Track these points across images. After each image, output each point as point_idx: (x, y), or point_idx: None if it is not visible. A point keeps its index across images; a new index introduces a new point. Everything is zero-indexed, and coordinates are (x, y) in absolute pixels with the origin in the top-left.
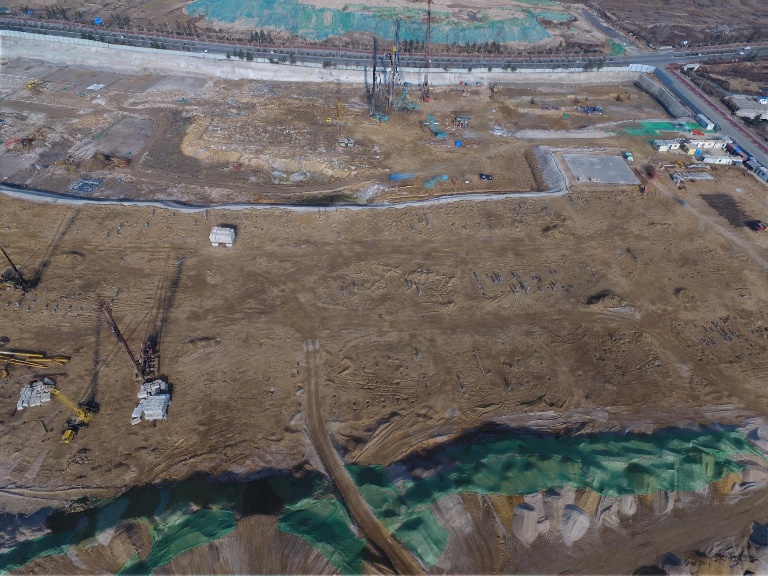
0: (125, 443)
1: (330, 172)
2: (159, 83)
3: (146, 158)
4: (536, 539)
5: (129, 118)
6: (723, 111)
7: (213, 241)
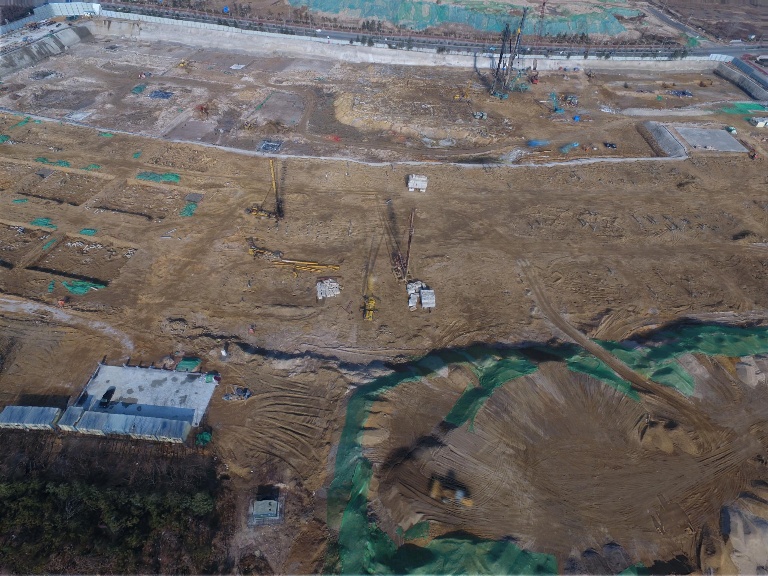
0: (412, 322)
1: (474, 139)
2: (291, 65)
3: (310, 125)
4: (758, 384)
5: (278, 93)
6: None
7: (410, 187)
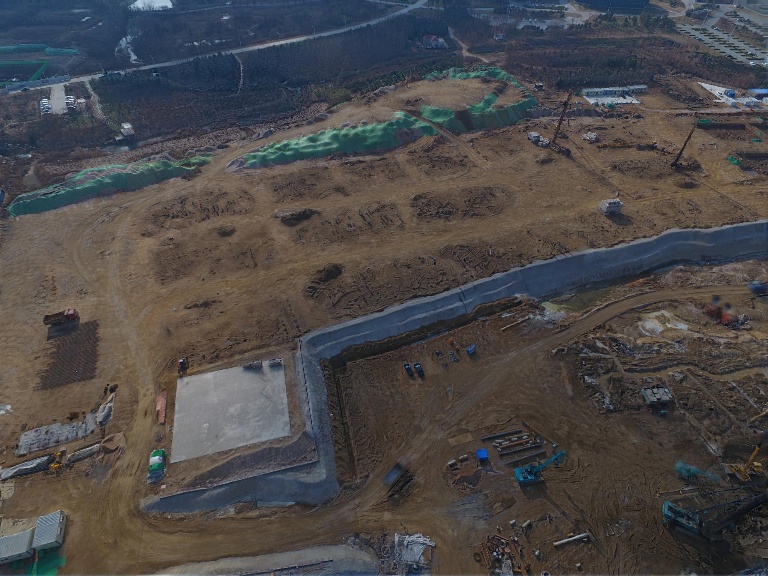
0: None
1: (622, 335)
2: None
3: None
4: None
5: None
6: None
7: None
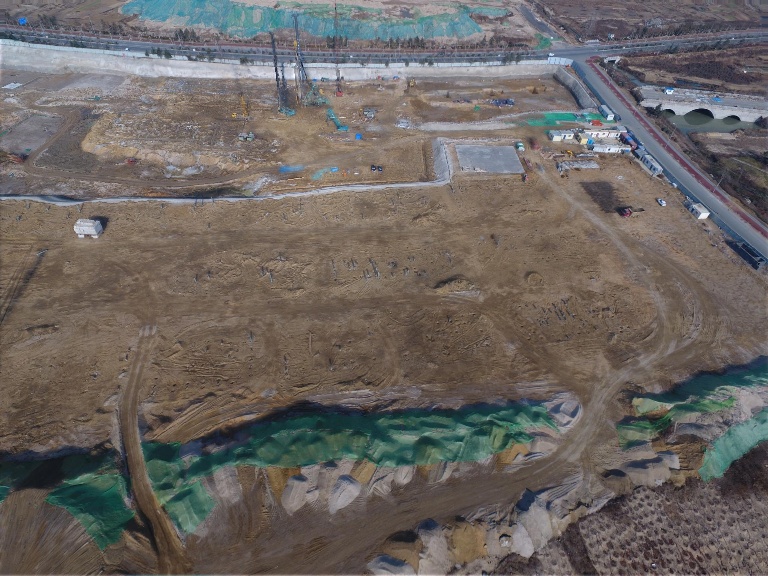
0: None
1: (223, 166)
2: (77, 81)
3: (44, 154)
4: (301, 508)
5: (38, 116)
6: (629, 102)
7: (78, 233)
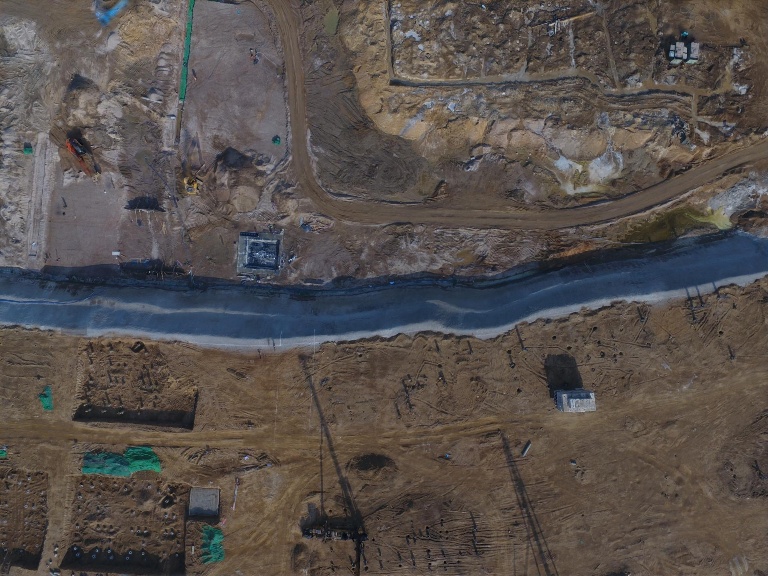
0: None
1: (662, 152)
2: None
3: (317, 153)
4: None
5: (204, 3)
6: None
7: None
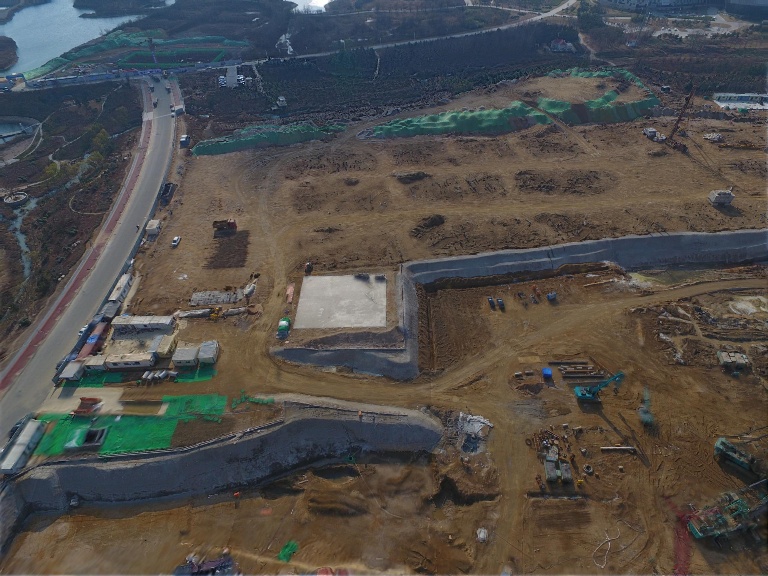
0: None
1: (708, 308)
2: None
3: None
4: None
5: None
6: None
7: None
